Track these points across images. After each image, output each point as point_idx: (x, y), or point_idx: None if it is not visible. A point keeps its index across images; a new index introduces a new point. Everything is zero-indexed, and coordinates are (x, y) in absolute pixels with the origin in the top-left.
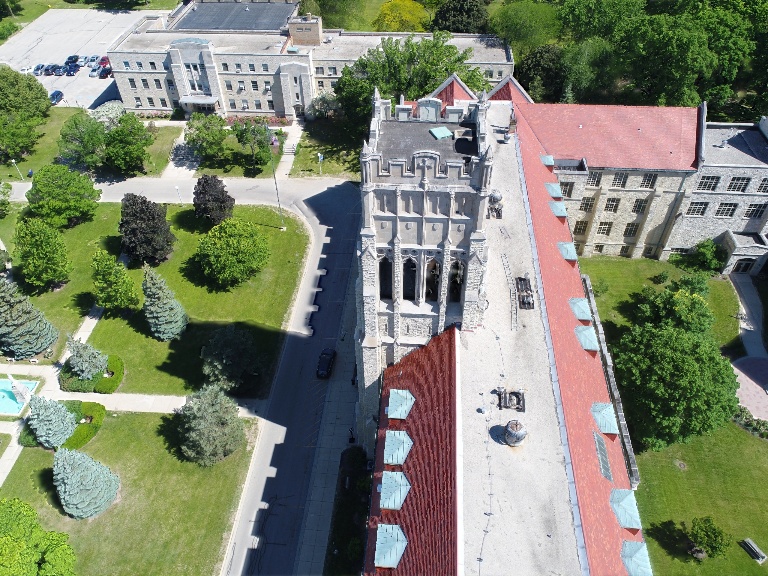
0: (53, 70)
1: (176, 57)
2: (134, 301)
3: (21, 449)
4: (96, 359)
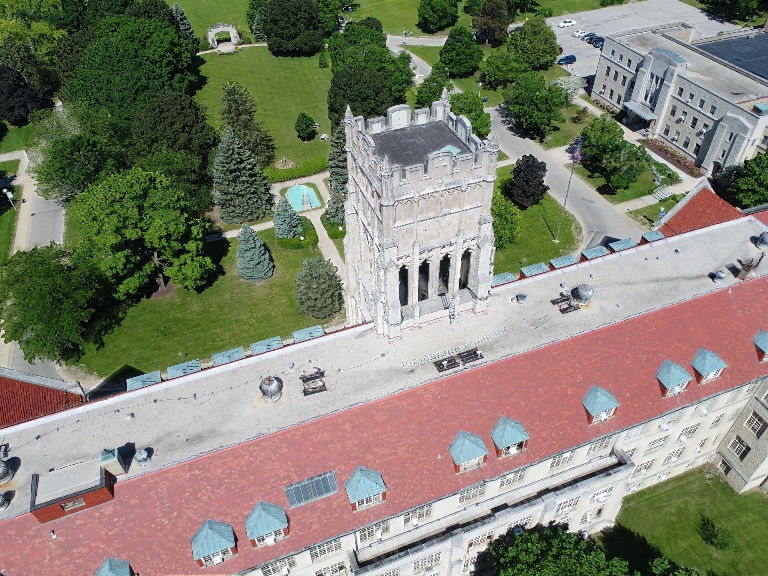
0: (596, 41)
1: (648, 63)
2: None
3: (273, 227)
4: (342, 213)
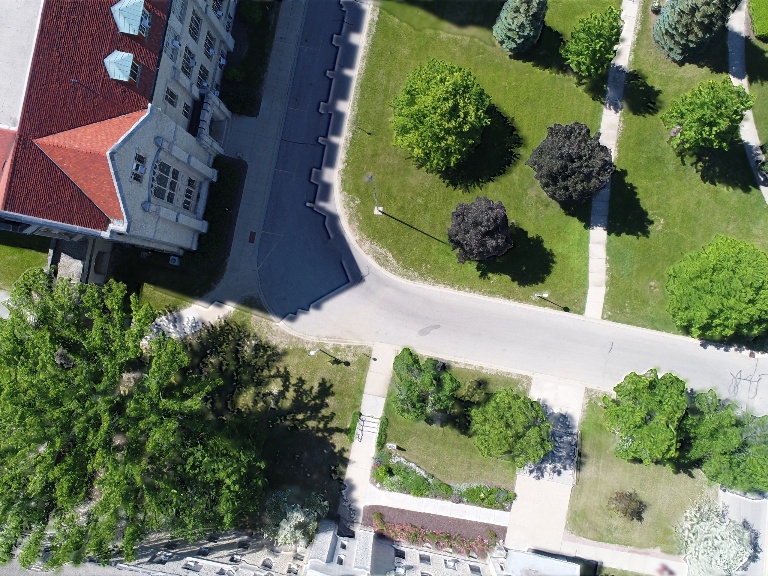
0: None
1: None
2: (566, 50)
3: None
4: None
